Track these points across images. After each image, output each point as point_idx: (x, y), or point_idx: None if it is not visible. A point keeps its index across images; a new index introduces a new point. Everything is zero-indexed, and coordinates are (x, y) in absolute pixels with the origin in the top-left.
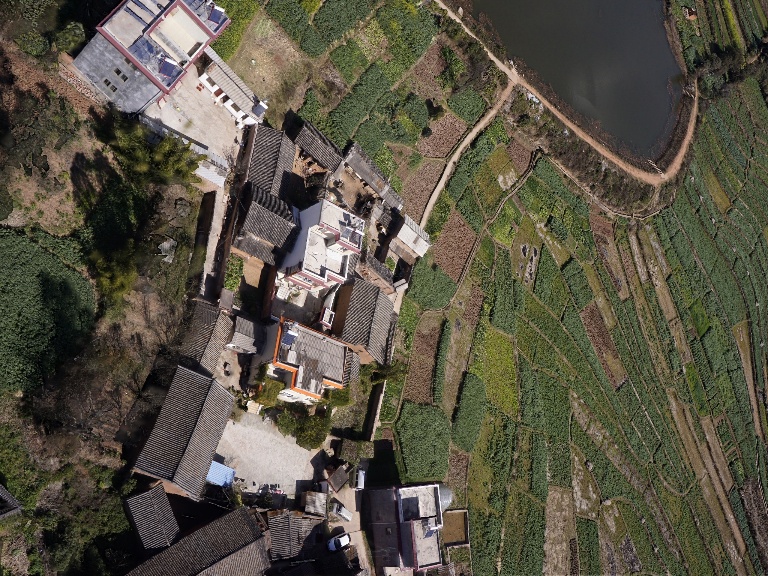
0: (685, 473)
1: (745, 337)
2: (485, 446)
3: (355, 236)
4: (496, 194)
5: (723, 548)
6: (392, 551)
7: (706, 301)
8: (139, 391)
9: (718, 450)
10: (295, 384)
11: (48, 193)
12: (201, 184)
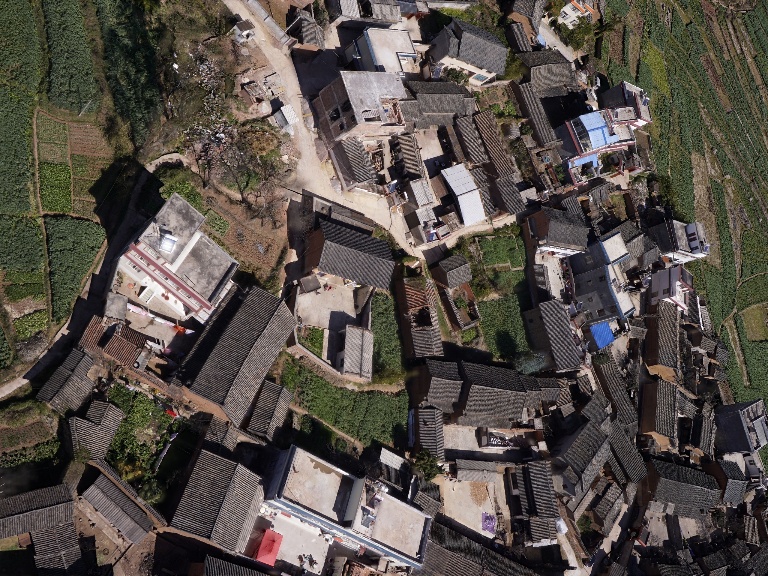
0: None
1: None
2: (654, 106)
3: None
4: None
5: None
6: None
7: None
8: None
9: None
10: None
11: None
12: None
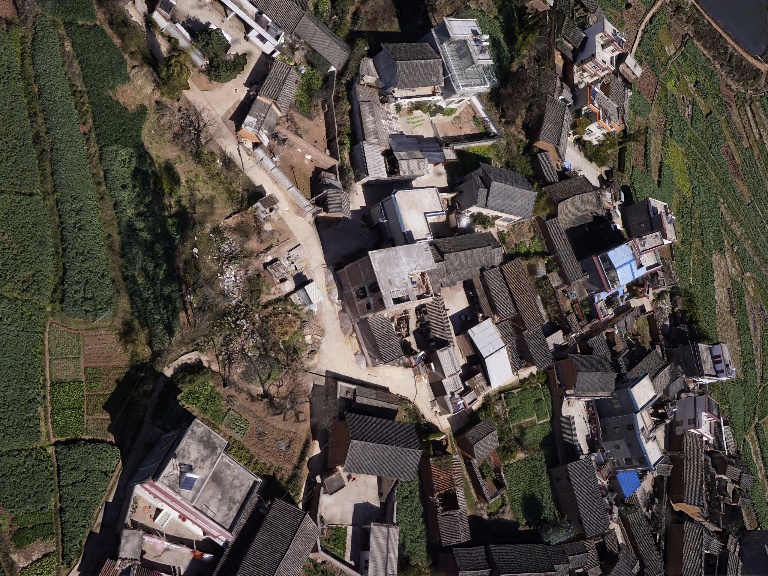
0: None
1: None
2: (676, 210)
3: (620, 43)
4: (665, 57)
5: None
6: None
7: None
8: (527, 108)
9: None
10: (599, 118)
11: None
12: (539, 5)
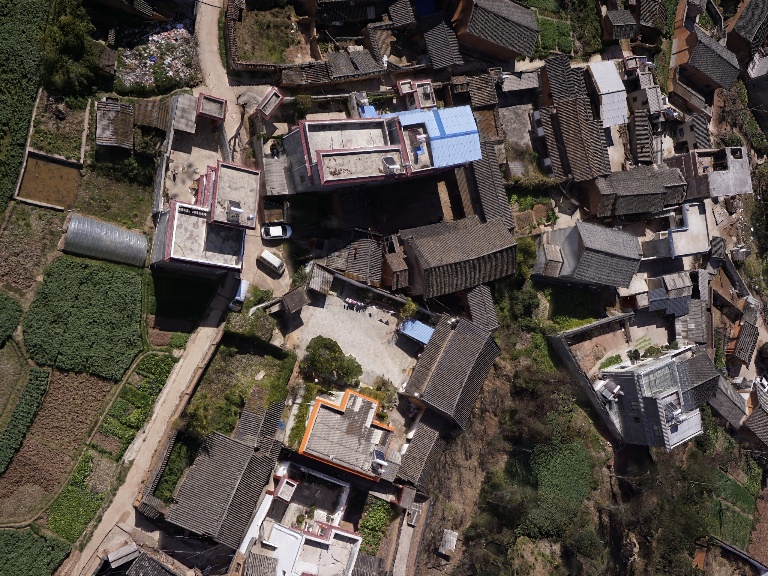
0: None
1: None
2: None
3: None
4: None
5: None
6: None
7: None
8: None
9: None
10: None
11: (528, 571)
12: None
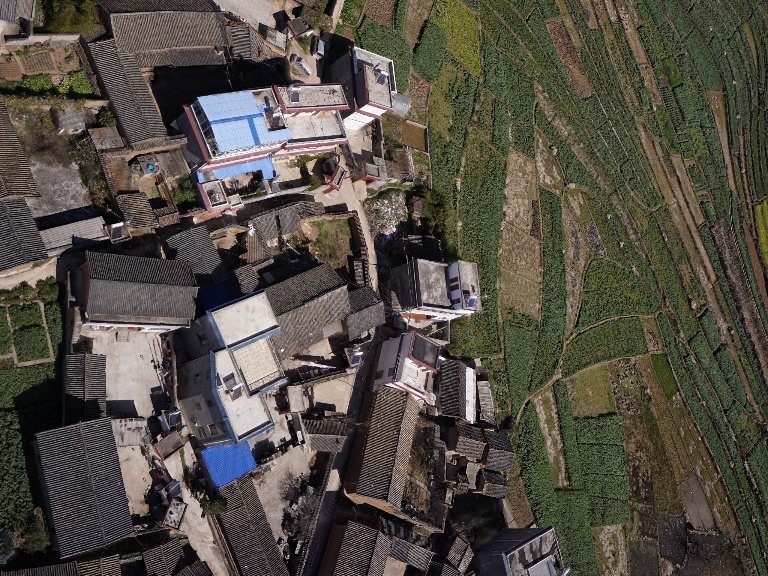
0: (653, 193)
1: (721, 106)
2: (446, 87)
3: None
4: None
5: (692, 269)
6: (349, 102)
7: (679, 61)
8: None
9: (689, 188)
10: None
11: None
12: None
